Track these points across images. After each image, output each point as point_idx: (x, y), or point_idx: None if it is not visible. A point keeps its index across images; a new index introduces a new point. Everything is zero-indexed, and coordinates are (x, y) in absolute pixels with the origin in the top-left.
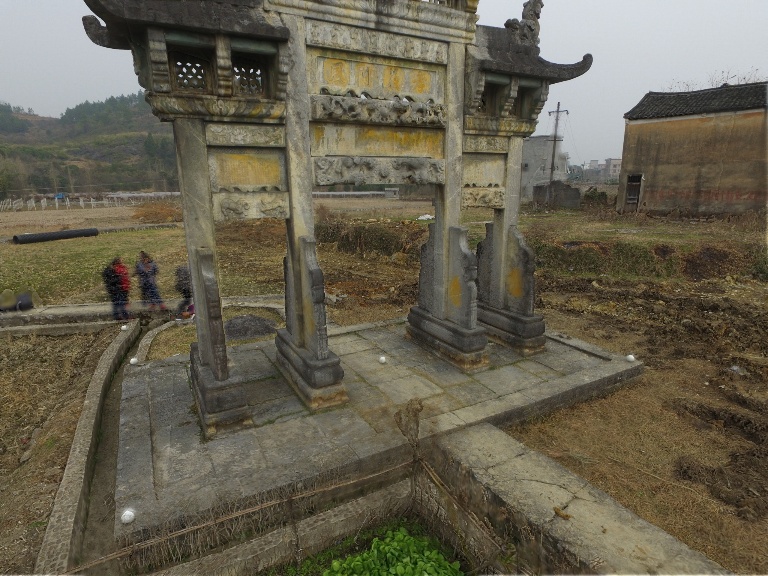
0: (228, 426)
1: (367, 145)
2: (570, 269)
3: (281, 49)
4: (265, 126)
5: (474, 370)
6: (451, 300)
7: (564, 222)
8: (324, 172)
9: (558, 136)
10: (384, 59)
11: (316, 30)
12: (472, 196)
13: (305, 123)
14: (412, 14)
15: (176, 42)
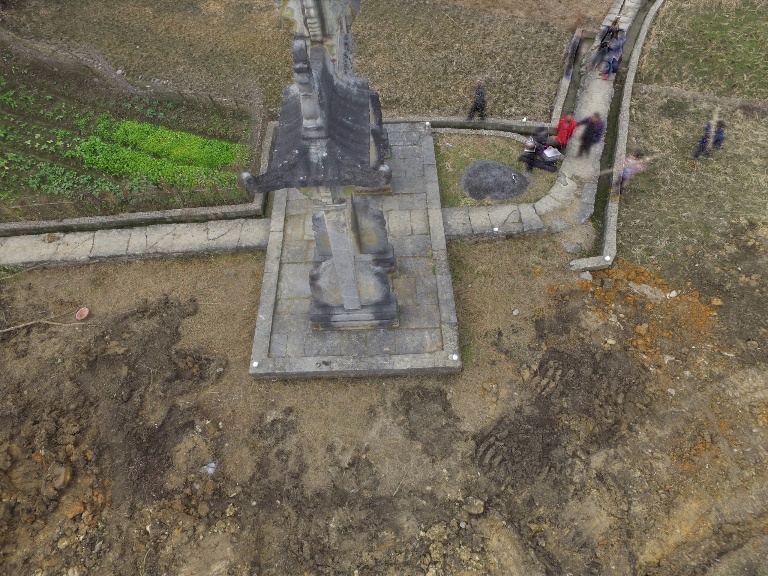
0: None
1: None
2: None
3: None
4: None
5: None
6: None
7: None
8: None
9: None
10: None
11: None
12: None
13: None
14: None
15: None
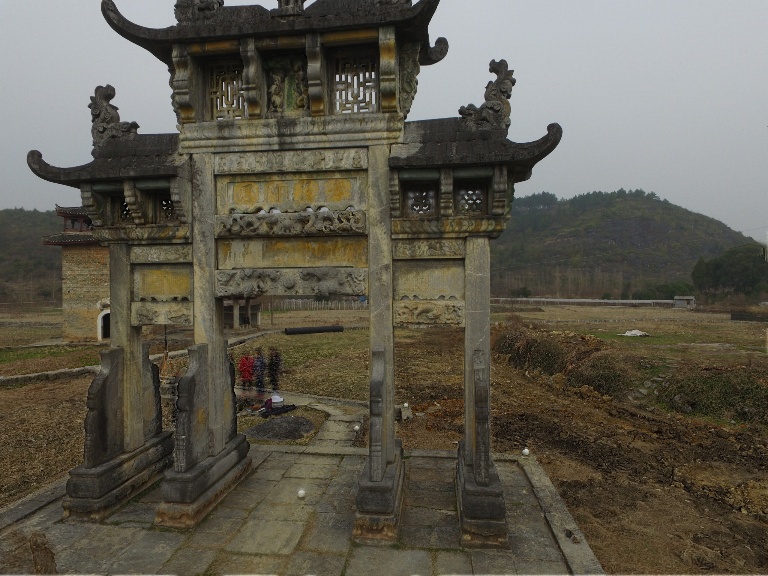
0: (80, 514)
1: (275, 257)
2: None
3: (172, 183)
4: (176, 245)
5: (367, 540)
6: None
7: None
8: (223, 284)
9: None
10: (294, 174)
11: (222, 161)
12: (408, 310)
13: (209, 240)
14: (318, 129)
15: (101, 190)
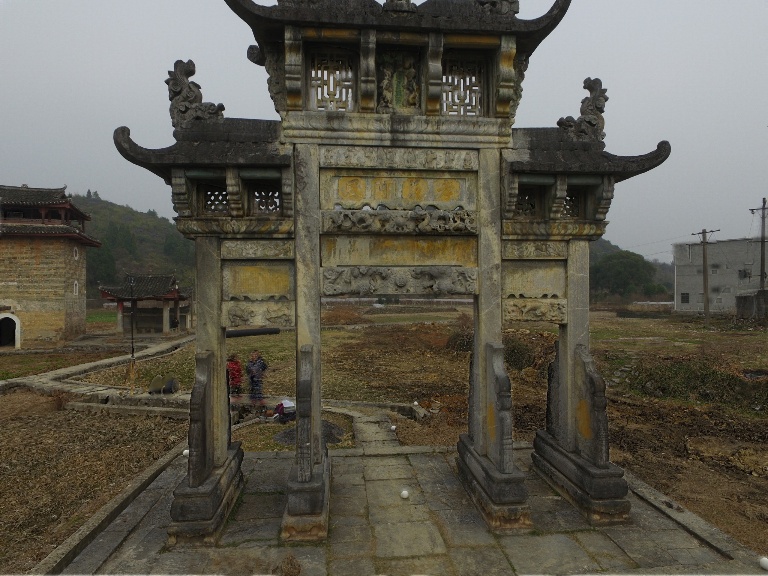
0: (189, 539)
1: (383, 255)
2: (754, 407)
3: (284, 173)
4: (276, 240)
5: (507, 531)
6: (489, 432)
7: (767, 343)
8: (331, 282)
9: (767, 236)
10: (403, 172)
11: (329, 154)
12: (517, 308)
13: (314, 236)
14: (432, 128)
15: (195, 177)
